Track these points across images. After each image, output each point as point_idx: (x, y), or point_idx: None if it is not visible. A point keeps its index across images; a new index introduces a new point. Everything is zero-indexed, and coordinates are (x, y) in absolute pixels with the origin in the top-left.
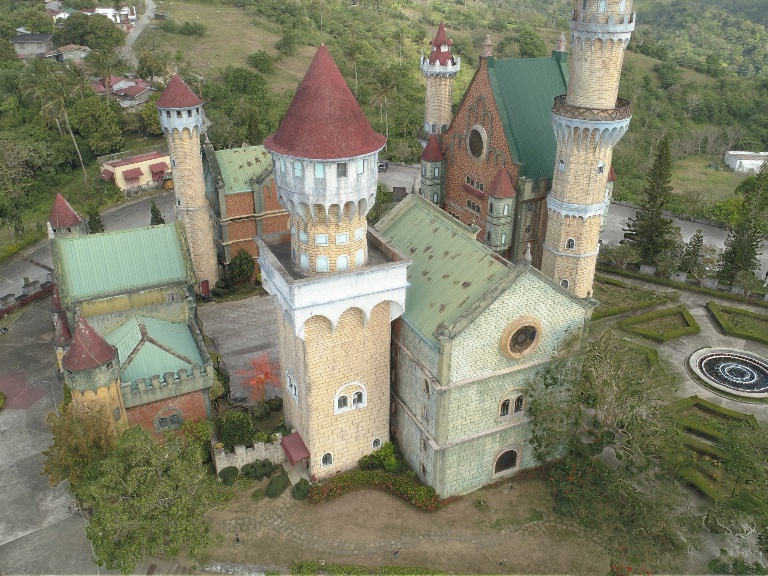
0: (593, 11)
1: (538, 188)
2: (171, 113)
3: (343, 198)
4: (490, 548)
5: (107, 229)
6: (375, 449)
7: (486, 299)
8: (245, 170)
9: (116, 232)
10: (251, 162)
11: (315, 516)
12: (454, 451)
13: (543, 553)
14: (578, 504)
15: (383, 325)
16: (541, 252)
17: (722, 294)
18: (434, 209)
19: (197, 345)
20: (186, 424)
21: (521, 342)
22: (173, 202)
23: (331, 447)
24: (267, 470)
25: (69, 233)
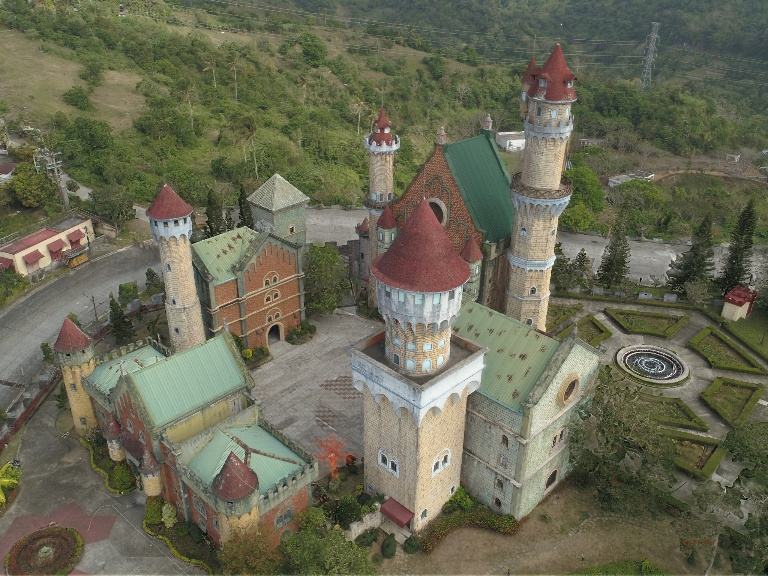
0: (547, 118)
1: (499, 248)
2: (168, 223)
3: (450, 315)
4: (569, 550)
5: (29, 323)
6: (451, 495)
7: (552, 369)
8: (223, 259)
9: (177, 355)
10: (226, 250)
11: (432, 563)
12: (527, 484)
13: (604, 543)
14: (623, 501)
15: (463, 399)
16: (501, 297)
17: (611, 299)
18: None
19: (283, 443)
20: (302, 516)
21: (568, 392)
22: (87, 281)
23: (427, 504)
24: (375, 536)
25: (83, 355)
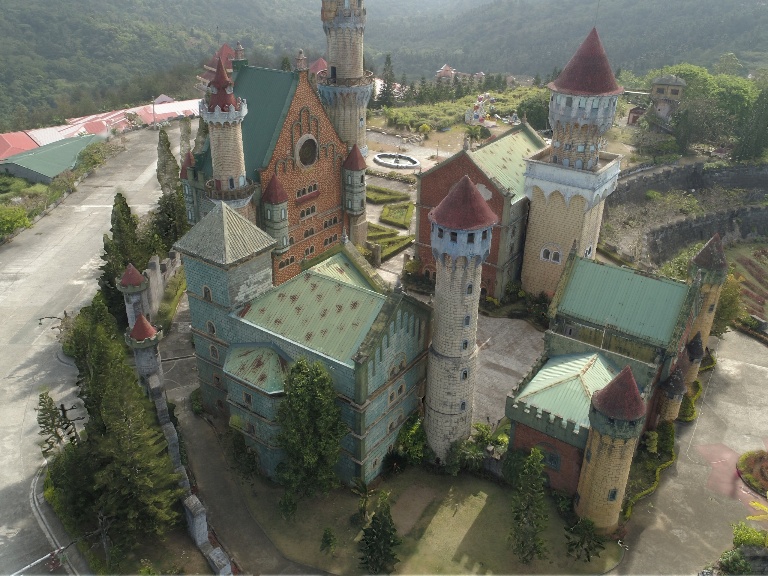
0: None
1: None
2: None
3: None
4: None
5: None
6: None
7: None
8: None
9: None
10: None
11: None
12: None
13: None
14: None
15: None
16: None
17: None
18: None
19: None
20: None
21: None
22: None
23: None
24: None
25: None
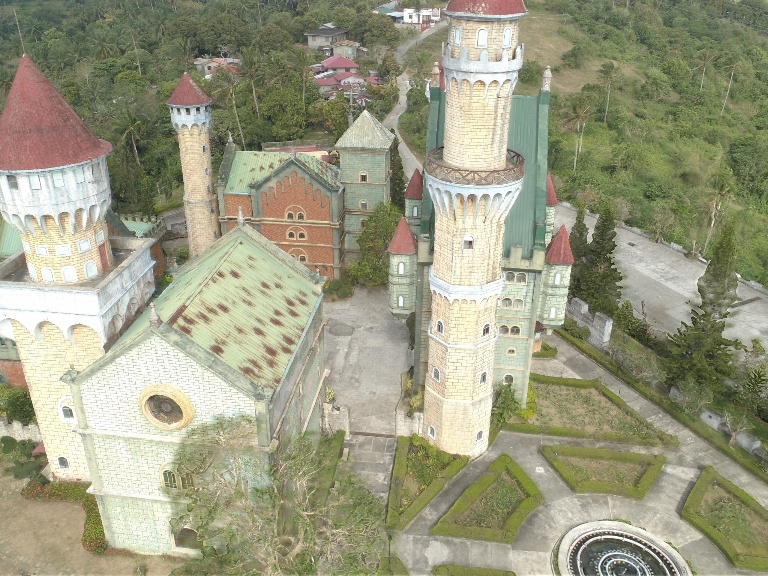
0: (451, 42)
1: None
2: (173, 109)
3: (22, 210)
4: None
5: None
6: None
7: (113, 351)
8: (254, 173)
9: None
10: (264, 167)
11: (20, 509)
12: (116, 502)
13: None
14: None
15: (96, 349)
16: None
17: (745, 463)
18: (262, 246)
19: None
20: None
21: (168, 412)
22: None
23: (66, 452)
24: None
25: None
